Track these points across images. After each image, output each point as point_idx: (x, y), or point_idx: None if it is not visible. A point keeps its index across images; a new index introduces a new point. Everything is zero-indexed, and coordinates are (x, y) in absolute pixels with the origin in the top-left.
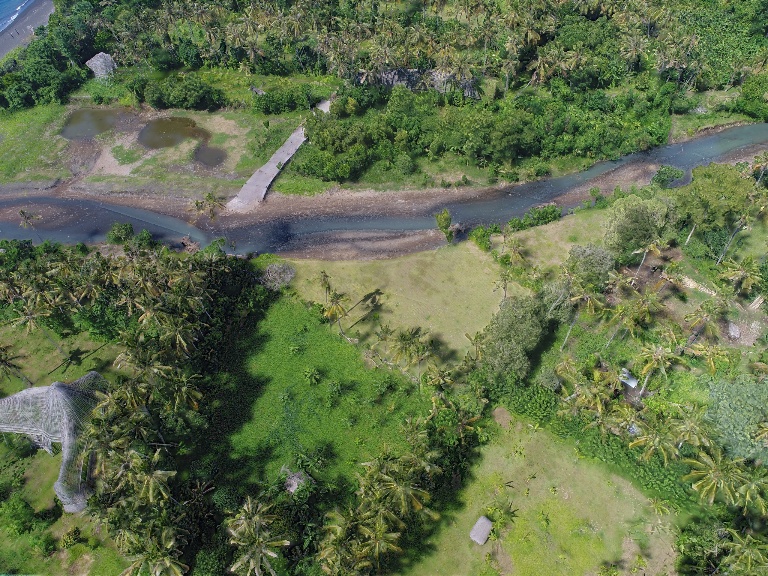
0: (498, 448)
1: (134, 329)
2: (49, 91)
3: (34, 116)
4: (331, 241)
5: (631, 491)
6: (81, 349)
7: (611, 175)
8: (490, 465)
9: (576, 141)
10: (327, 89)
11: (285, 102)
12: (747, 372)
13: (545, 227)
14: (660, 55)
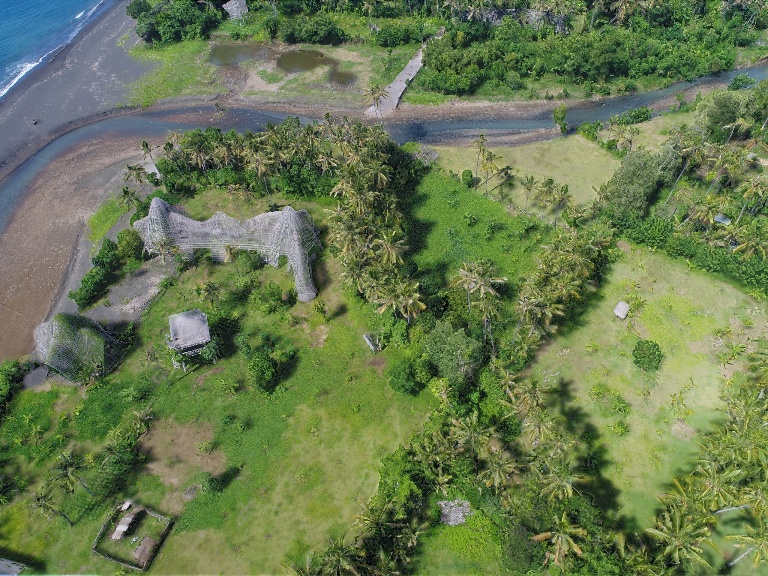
0: (624, 265)
1: (323, 186)
2: (196, 28)
3: (184, 48)
4: (460, 136)
5: (732, 290)
6: (277, 204)
7: (688, 91)
8: (620, 275)
9: (658, 63)
10: (433, 28)
11: (401, 36)
12: None
13: (639, 125)
14: None
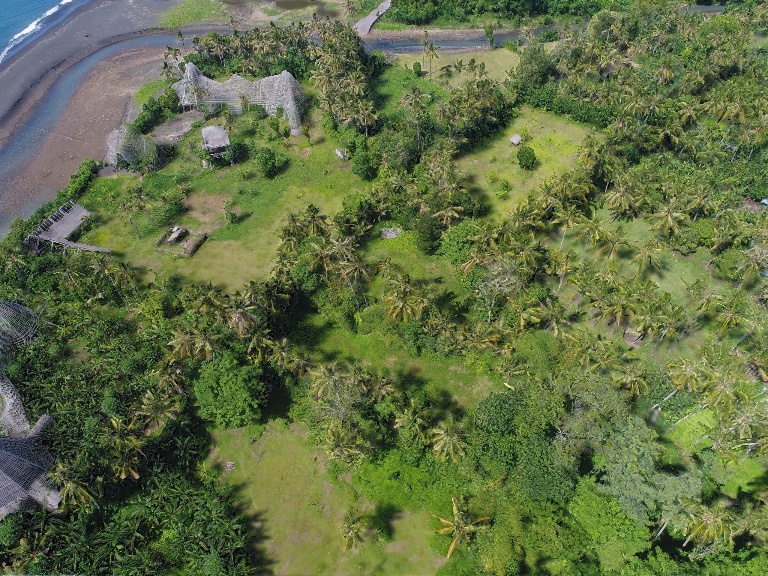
0: (523, 119)
1: None
2: None
3: None
4: (416, 50)
5: None
6: None
7: None
8: (519, 124)
9: None
10: None
11: None
12: None
13: (550, 43)
14: None
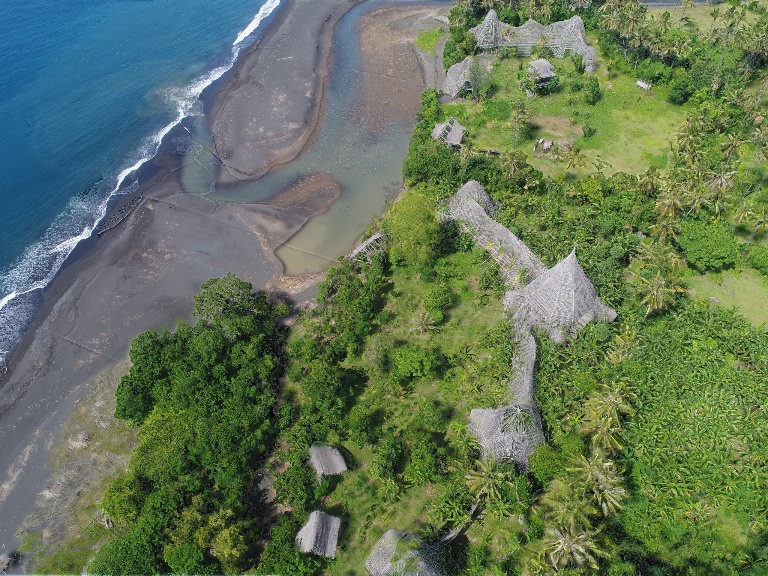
0: None
1: None
2: None
3: None
4: None
5: None
6: None
7: None
8: None
9: None
10: None
11: None
12: None
13: None
14: None
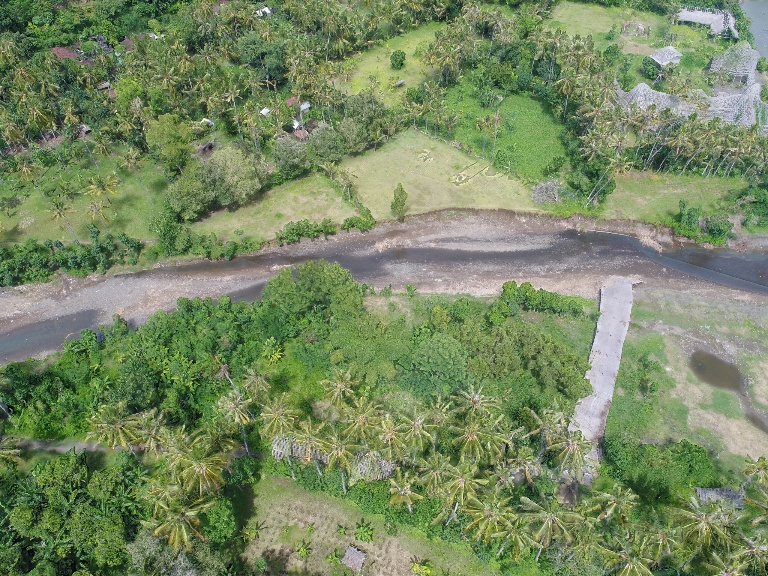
0: None
1: None
2: None
3: None
4: (508, 240)
5: None
6: None
7: None
8: None
9: None
10: None
11: None
12: (218, 132)
13: None
14: (2, 373)
